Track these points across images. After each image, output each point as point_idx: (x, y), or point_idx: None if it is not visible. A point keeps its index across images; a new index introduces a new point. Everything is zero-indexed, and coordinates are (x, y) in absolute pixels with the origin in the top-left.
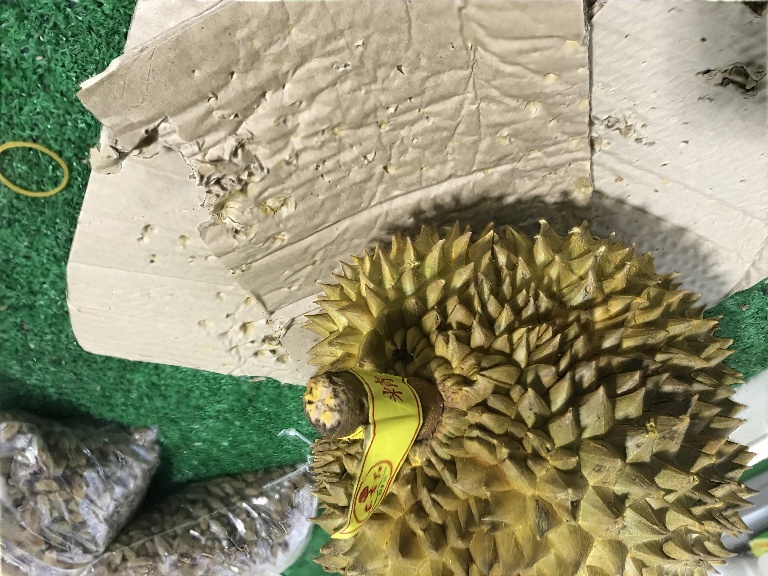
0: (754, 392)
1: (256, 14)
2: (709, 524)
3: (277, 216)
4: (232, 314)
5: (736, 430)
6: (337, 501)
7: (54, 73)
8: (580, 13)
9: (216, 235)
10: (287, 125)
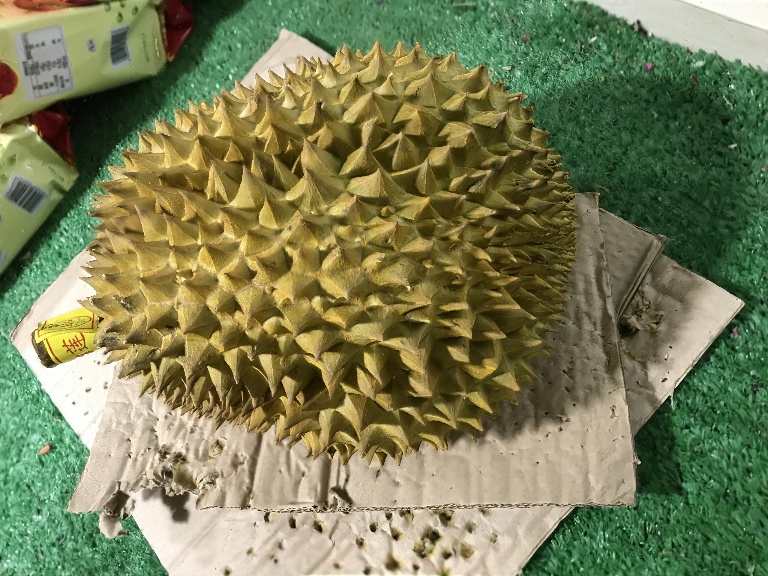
0: None
1: (111, 416)
2: None
3: None
4: (371, 569)
5: (711, 27)
6: None
7: (137, 574)
8: None
9: None
10: None
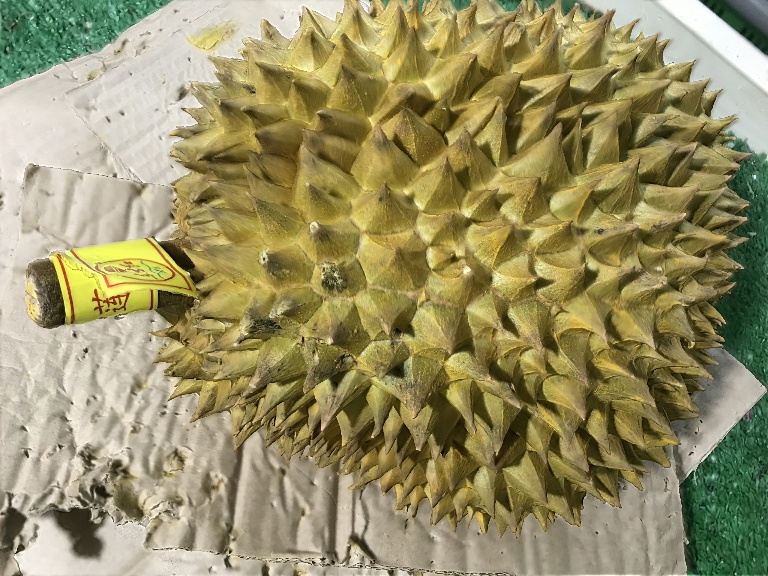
0: (715, 108)
1: None
2: (428, 8)
3: (187, 469)
4: None
5: (762, 116)
6: (238, 366)
7: None
8: (109, 179)
9: (164, 535)
10: (105, 416)
